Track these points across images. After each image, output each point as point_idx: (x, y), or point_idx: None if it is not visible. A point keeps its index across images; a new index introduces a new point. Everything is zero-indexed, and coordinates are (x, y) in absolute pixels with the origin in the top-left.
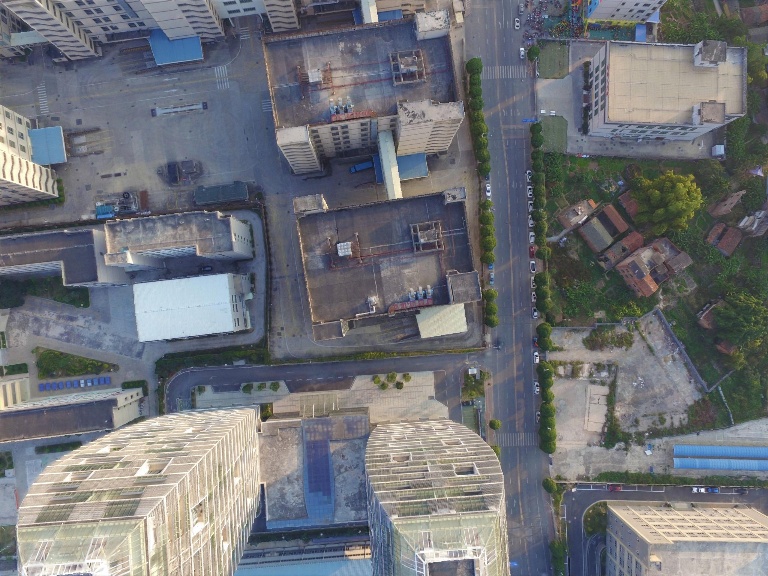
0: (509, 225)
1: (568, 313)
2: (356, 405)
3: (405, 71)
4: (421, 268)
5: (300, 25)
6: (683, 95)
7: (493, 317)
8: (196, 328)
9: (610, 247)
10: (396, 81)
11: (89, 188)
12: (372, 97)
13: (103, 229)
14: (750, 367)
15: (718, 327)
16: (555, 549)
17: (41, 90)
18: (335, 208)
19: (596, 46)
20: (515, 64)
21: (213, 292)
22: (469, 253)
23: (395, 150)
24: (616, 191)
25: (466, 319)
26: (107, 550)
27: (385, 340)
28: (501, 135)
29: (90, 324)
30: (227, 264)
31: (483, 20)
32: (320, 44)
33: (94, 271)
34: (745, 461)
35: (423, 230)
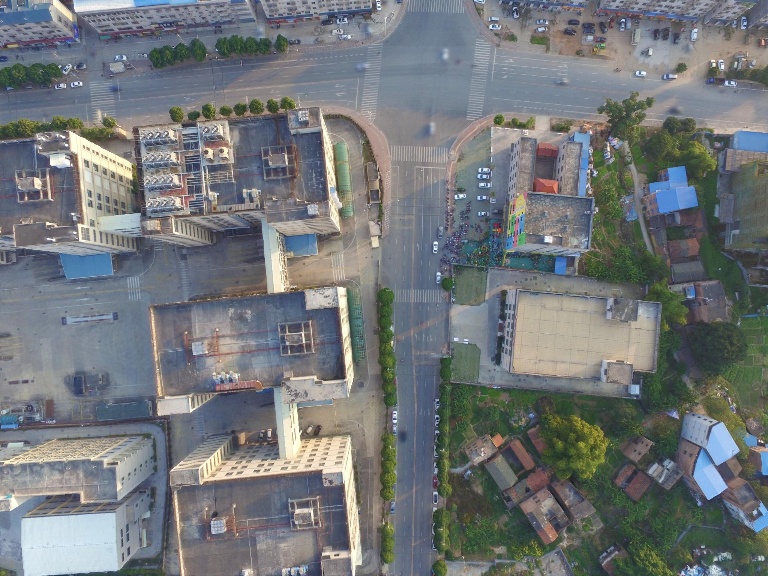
0: (414, 453)
1: (467, 550)
2: None
3: None
4: (298, 543)
5: (215, 239)
6: (592, 348)
7: (387, 555)
8: (81, 566)
9: (514, 485)
10: (283, 352)
11: None
12: (259, 365)
13: (8, 435)
14: None
15: None
16: None
17: None
18: None
19: (515, 274)
20: (431, 288)
21: (100, 531)
22: (347, 530)
23: None
24: (526, 425)
25: (365, 546)
26: None
27: None
28: (412, 361)
29: None
30: None
31: (401, 241)
32: (210, 309)
33: None
34: None
35: (302, 505)
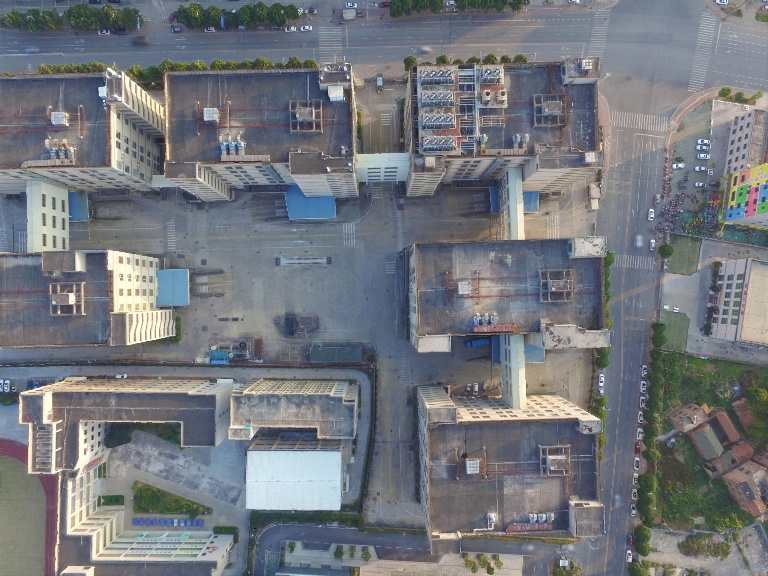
0: (618, 418)
1: (668, 517)
2: None
3: (554, 291)
4: (544, 490)
5: None
6: None
7: None
8: (304, 502)
9: None
10: (543, 298)
11: (205, 329)
12: (516, 310)
13: (214, 371)
14: None
15: None
16: None
17: (171, 226)
18: None
19: (728, 246)
20: (644, 255)
21: (325, 469)
22: (595, 481)
23: None
24: (731, 397)
25: None
26: None
27: None
28: (621, 325)
29: (190, 464)
30: None
31: (617, 206)
32: (471, 251)
33: (212, 435)
34: None
35: (551, 452)
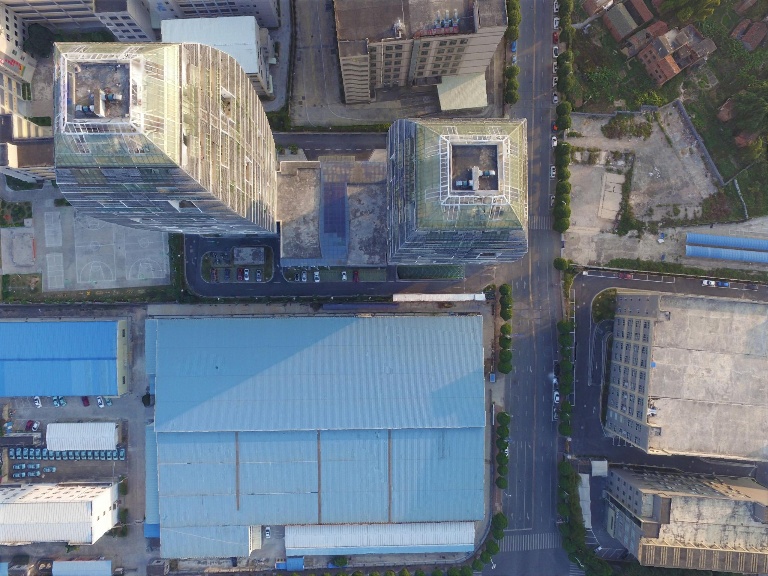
0: (534, 10)
1: (588, 97)
2: None
3: None
4: None
5: None
6: None
7: (514, 91)
8: None
9: (634, 34)
10: None
11: None
12: None
13: None
14: (767, 161)
15: (738, 117)
16: (563, 324)
17: None
18: None
19: None
20: None
21: (239, 32)
22: None
23: None
24: None
25: None
26: (144, 51)
27: (405, 116)
28: None
29: None
30: None
31: None
32: None
33: (124, 2)
34: (757, 253)
35: None
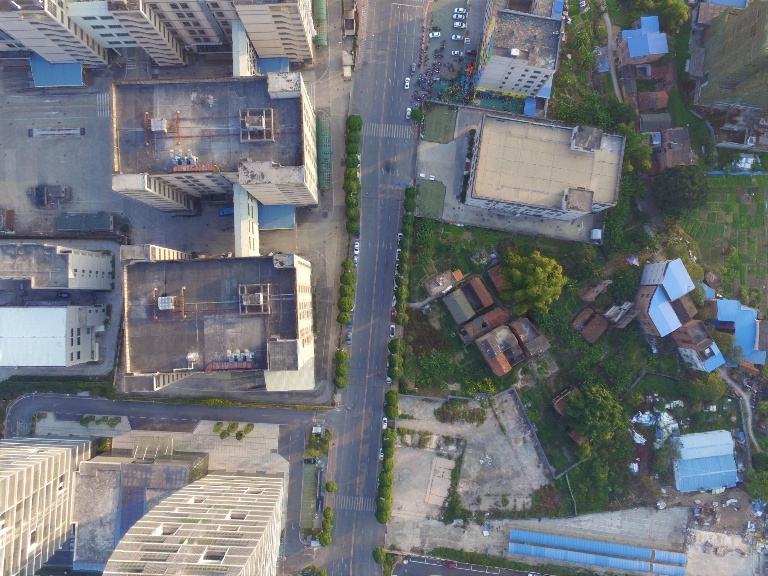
0: (374, 286)
1: (420, 382)
2: (196, 449)
3: (252, 129)
4: (246, 329)
5: (187, 61)
6: (555, 178)
7: (340, 379)
8: (28, 359)
9: (471, 321)
10: (243, 138)
11: None
12: (218, 151)
13: None
14: (600, 459)
15: (570, 415)
16: None
17: None
18: (162, 260)
19: None
20: (400, 124)
21: (49, 325)
22: None
23: (258, 200)
24: (487, 264)
25: (319, 376)
26: None
27: (234, 387)
28: (377, 194)
29: None
30: (85, 293)
31: (374, 76)
32: (172, 92)
33: None
34: (582, 554)
35: (252, 291)
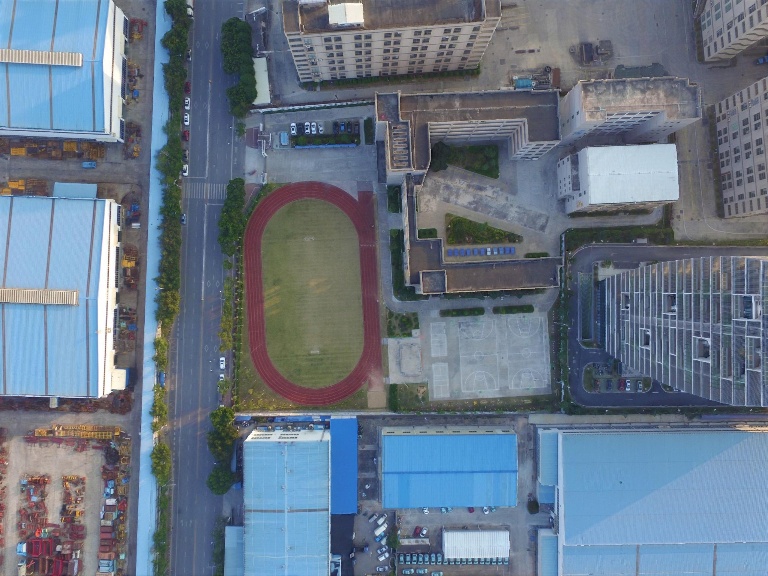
0: None
1: None
2: None
3: None
4: None
5: None
6: None
7: None
8: (644, 194)
9: None
10: None
11: (503, 62)
12: None
13: None
14: None
15: None
16: None
17: None
18: None
19: None
20: None
21: (662, 160)
22: None
23: None
24: None
25: None
26: None
27: None
28: None
29: (498, 195)
30: None
31: None
32: None
33: (555, 131)
34: None
35: None
